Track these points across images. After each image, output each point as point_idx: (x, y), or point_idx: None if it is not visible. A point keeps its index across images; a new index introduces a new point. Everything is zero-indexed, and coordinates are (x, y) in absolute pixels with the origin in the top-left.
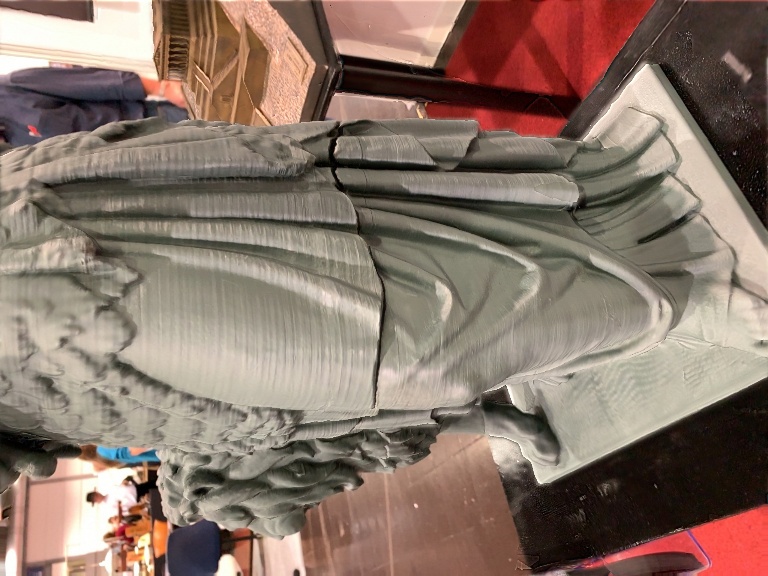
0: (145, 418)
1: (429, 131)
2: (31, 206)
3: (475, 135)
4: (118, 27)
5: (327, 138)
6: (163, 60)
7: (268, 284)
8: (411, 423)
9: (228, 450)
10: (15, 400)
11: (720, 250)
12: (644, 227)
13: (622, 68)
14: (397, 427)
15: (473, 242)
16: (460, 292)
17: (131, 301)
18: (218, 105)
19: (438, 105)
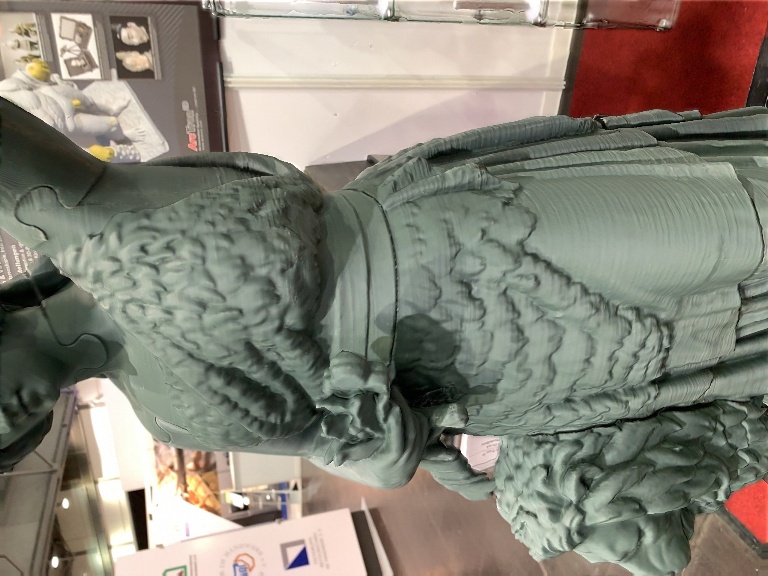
0: (546, 332)
1: None
2: (422, 158)
3: None
4: None
5: None
6: None
7: (620, 176)
8: (760, 385)
9: (606, 409)
10: (443, 312)
11: None
12: None
13: (760, 95)
14: (747, 394)
15: (757, 143)
16: None
17: (523, 199)
18: None
19: None
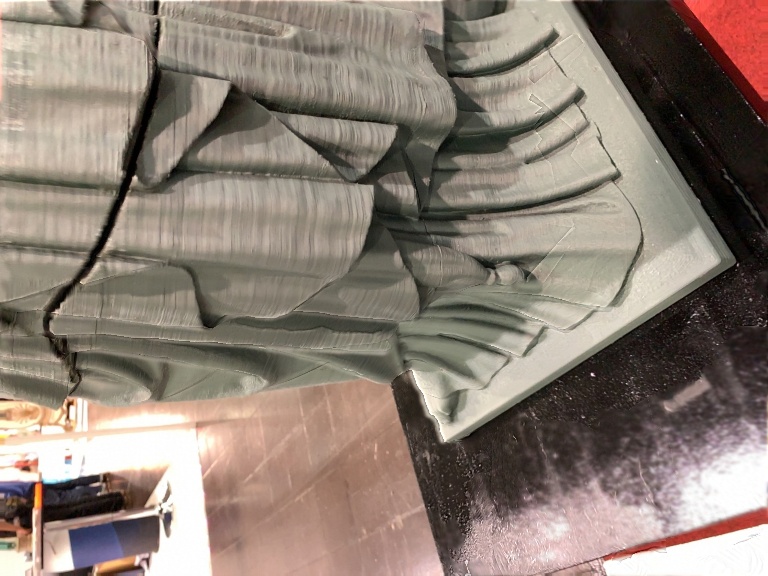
0: None
1: (254, 270)
2: None
3: (322, 286)
4: None
5: (47, 295)
6: None
7: None
8: None
9: None
10: None
11: (478, 381)
12: (459, 332)
13: (759, 179)
14: None
15: None
16: (171, 380)
17: None
18: None
19: None
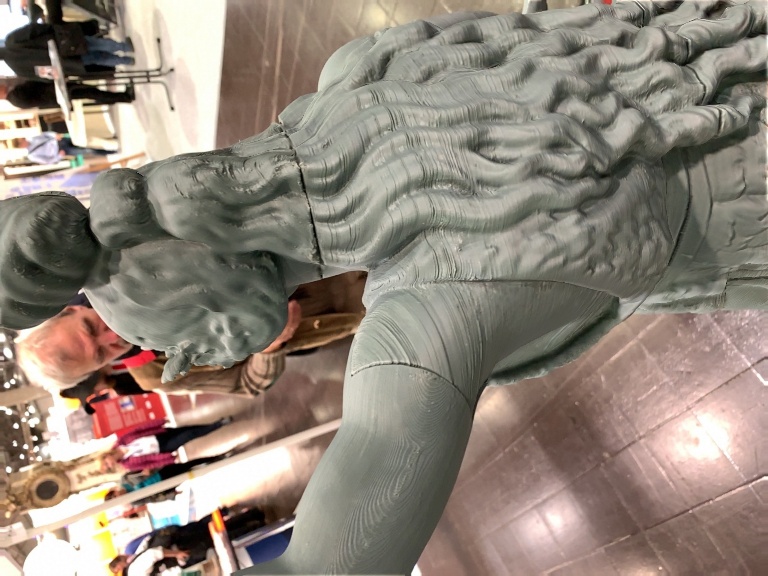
0: None
1: None
2: None
3: None
4: None
5: None
6: None
7: (767, 290)
8: None
9: None
10: None
11: None
12: None
13: None
14: None
15: None
16: None
17: None
18: None
19: None
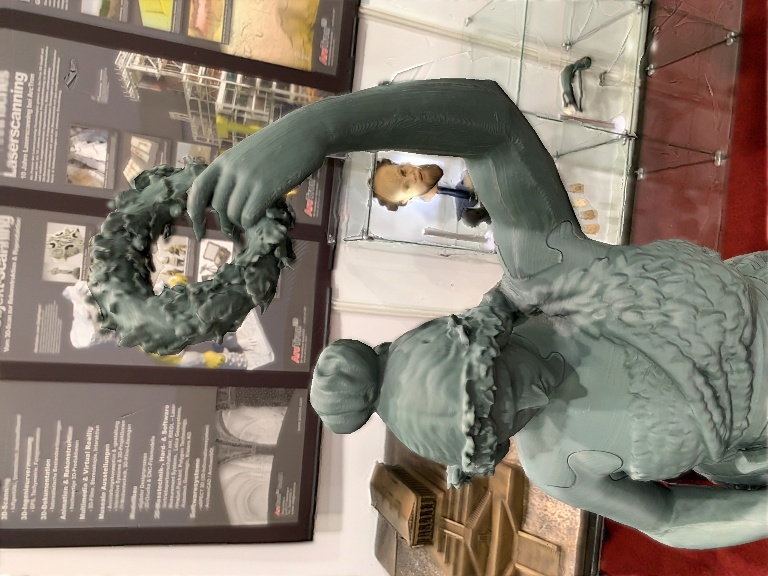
0: None
1: None
2: None
3: None
4: (320, 551)
5: None
6: (415, 523)
7: None
8: None
9: None
10: None
11: None
12: None
13: None
14: None
15: None
16: None
17: None
18: (476, 546)
19: (614, 556)
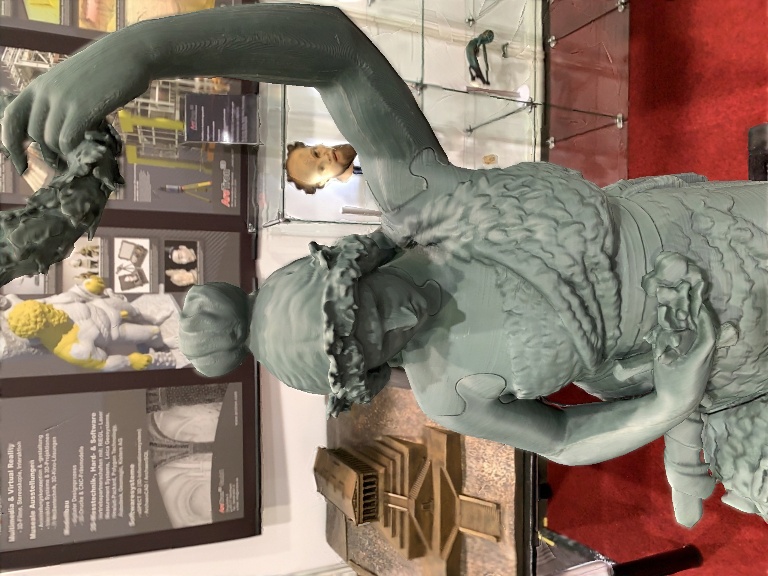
0: (764, 276)
1: None
2: None
3: None
4: (271, 545)
5: None
6: (359, 501)
7: None
8: None
9: None
10: None
11: None
12: None
13: None
14: None
15: None
16: None
17: None
18: (420, 516)
19: (560, 514)
